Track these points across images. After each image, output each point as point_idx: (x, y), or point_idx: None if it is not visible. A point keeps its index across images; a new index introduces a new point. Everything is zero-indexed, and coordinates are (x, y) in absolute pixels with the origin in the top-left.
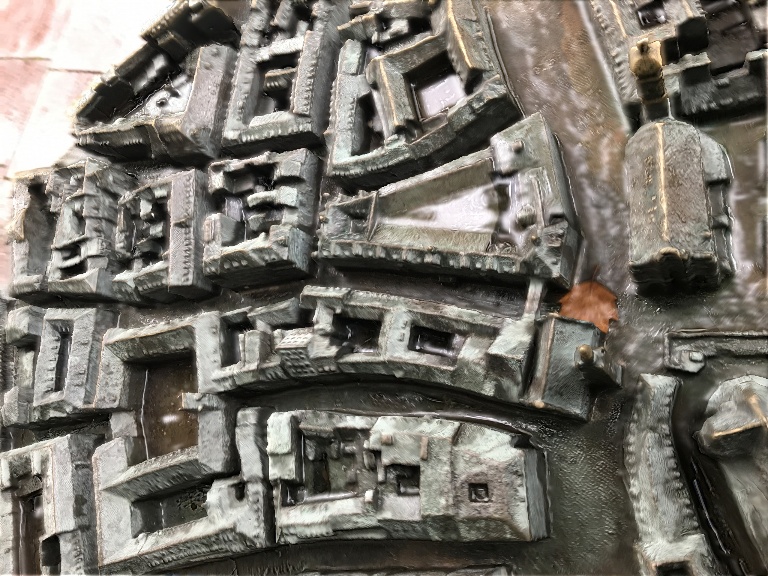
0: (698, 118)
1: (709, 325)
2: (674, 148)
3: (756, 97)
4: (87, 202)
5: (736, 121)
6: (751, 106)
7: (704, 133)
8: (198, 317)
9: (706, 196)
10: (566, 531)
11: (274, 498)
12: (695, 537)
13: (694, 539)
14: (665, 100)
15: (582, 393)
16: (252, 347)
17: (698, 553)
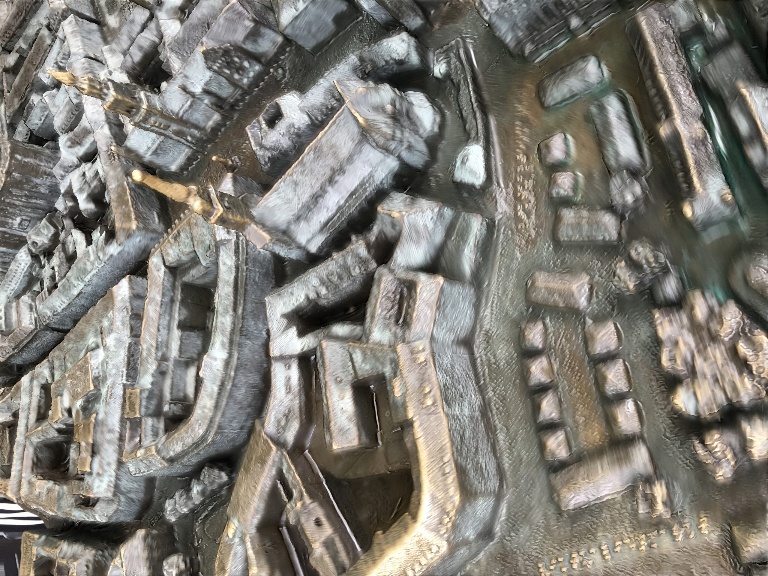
0: None
1: (483, 69)
2: None
3: None
4: None
5: None
6: None
7: None
8: None
9: None
10: (320, 63)
11: None
12: (306, 118)
13: (303, 117)
14: None
15: None
16: None
17: (293, 121)
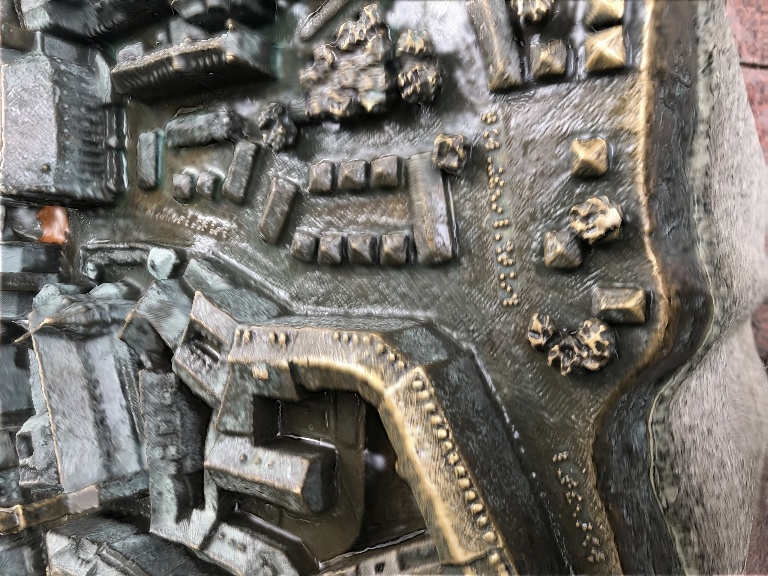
0: (103, 40)
1: (113, 236)
2: (18, 88)
3: (124, 20)
4: None
5: (132, 41)
6: (129, 27)
7: (101, 56)
8: None
9: (96, 121)
10: None
11: None
12: None
13: (46, 414)
14: (13, 39)
15: (16, 300)
16: None
17: (40, 425)
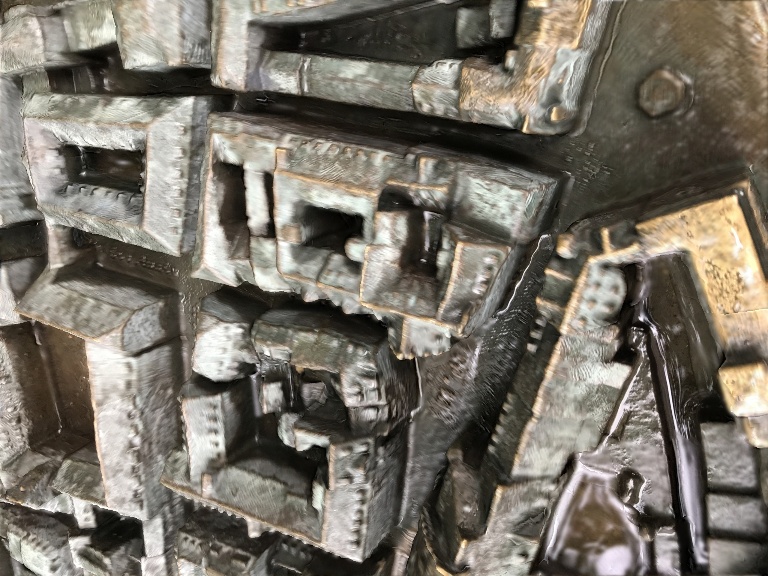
0: None
1: None
2: None
3: None
4: (351, 297)
5: None
6: None
7: None
8: (130, 504)
9: None
10: None
11: (2, 520)
12: None
13: None
14: None
15: None
16: (94, 571)
17: None
